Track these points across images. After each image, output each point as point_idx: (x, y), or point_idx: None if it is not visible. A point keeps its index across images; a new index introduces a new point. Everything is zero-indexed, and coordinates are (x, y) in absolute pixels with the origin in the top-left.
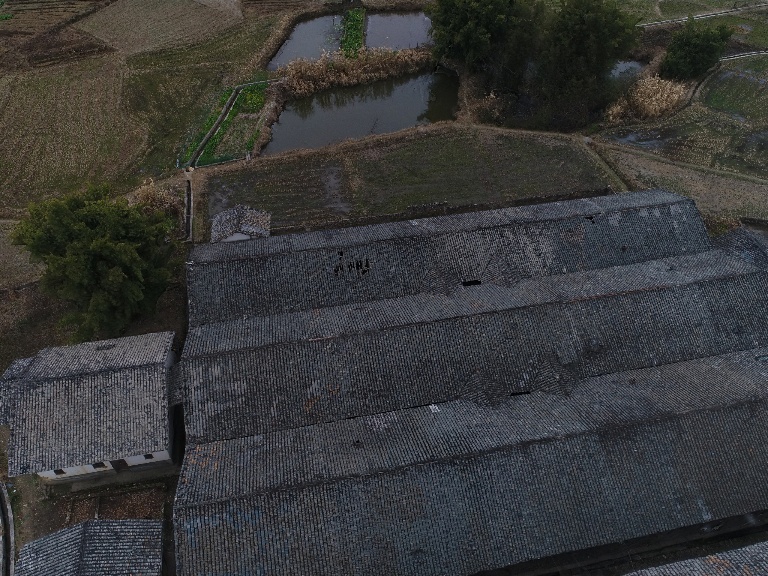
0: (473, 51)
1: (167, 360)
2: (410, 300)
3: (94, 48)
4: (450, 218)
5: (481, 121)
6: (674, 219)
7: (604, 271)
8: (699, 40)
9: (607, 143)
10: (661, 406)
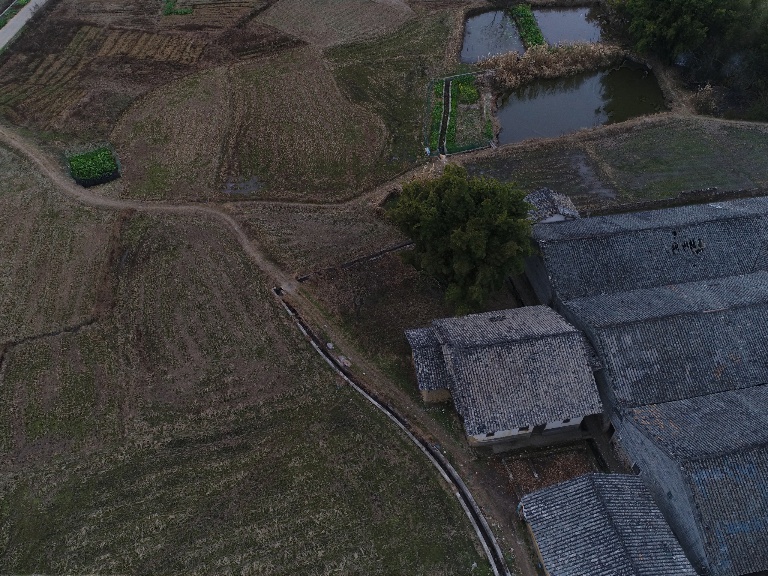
0: (683, 44)
1: None
2: (757, 277)
3: (287, 41)
4: (748, 202)
5: (697, 112)
6: None
7: None
8: None
9: None
10: None
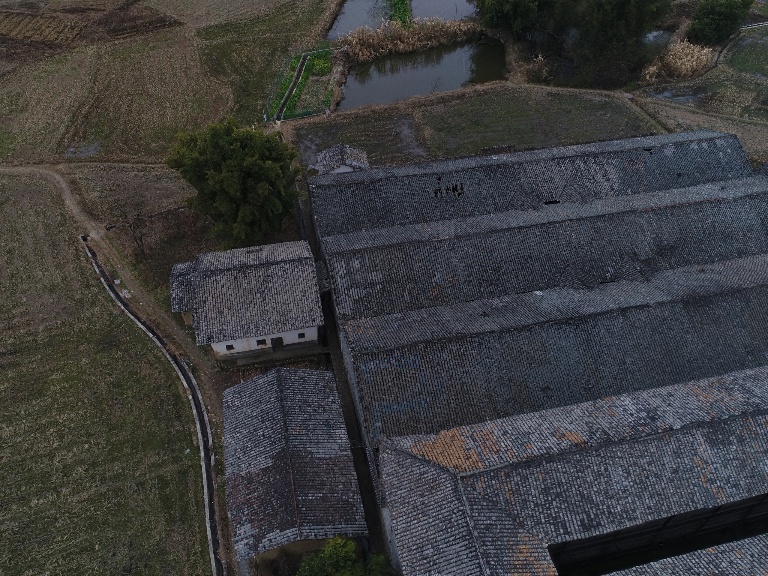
0: (521, 19)
1: None
2: (503, 215)
3: (164, 22)
4: (524, 153)
5: (530, 81)
6: (720, 151)
7: (664, 192)
8: (723, 8)
9: (646, 98)
10: (730, 284)
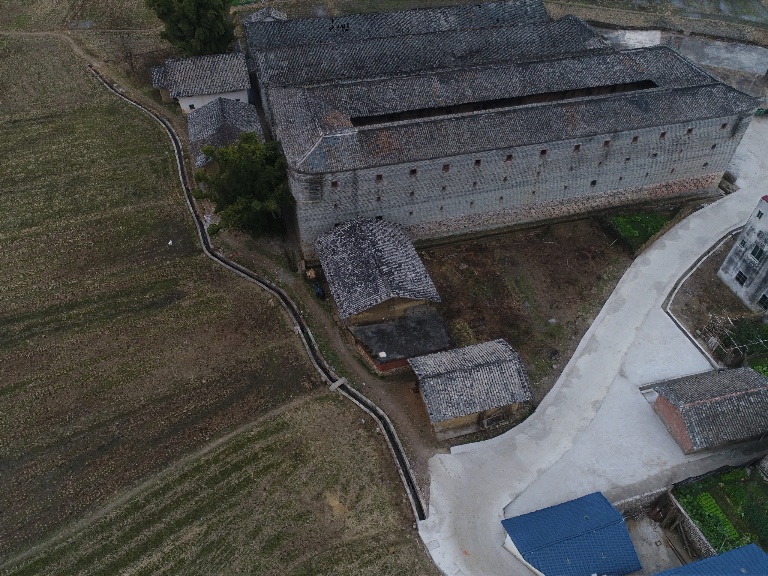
0: None
1: None
2: None
3: None
4: None
5: None
6: (528, 6)
7: None
8: None
9: None
10: None
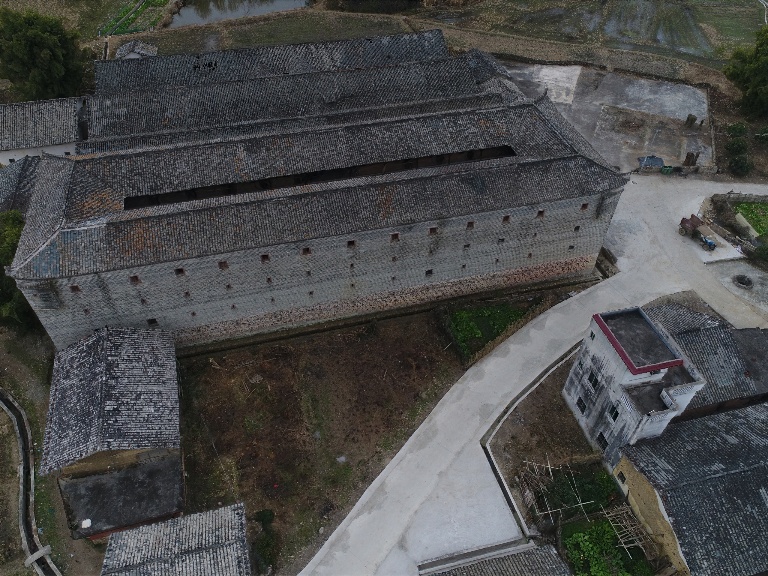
0: None
1: (80, 106)
2: None
3: None
4: None
5: (330, 9)
6: (426, 40)
7: None
8: None
9: (418, 19)
10: None
